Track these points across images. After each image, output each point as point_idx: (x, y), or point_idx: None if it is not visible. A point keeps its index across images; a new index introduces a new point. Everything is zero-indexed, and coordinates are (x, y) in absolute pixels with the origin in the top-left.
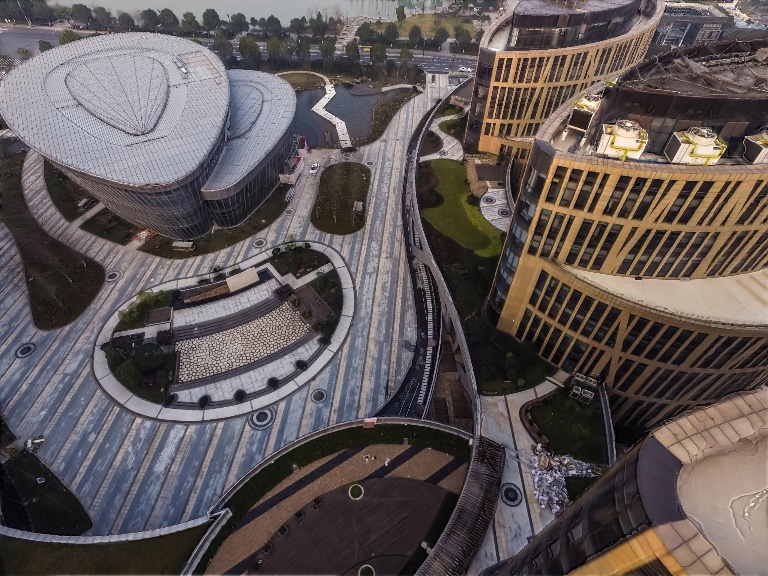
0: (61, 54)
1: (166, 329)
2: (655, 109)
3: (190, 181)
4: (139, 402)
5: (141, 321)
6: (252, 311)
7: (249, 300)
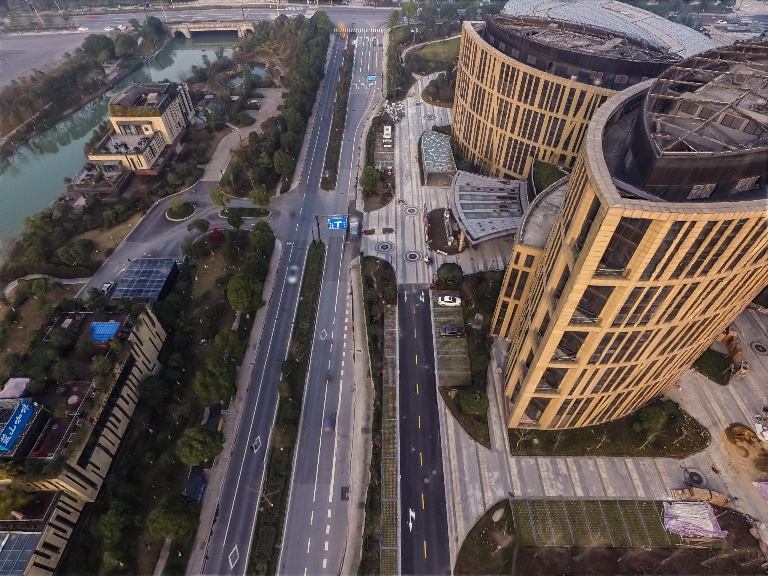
0: (521, 6)
1: None
2: None
3: None
4: None
5: None
6: None
7: None
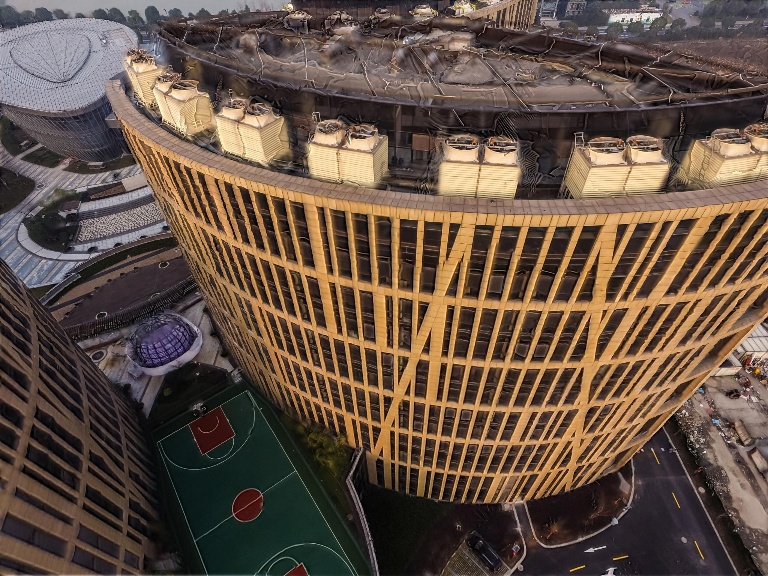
0: (10, 35)
1: (74, 213)
2: (315, 3)
3: (93, 110)
4: (46, 251)
5: (56, 209)
6: (139, 201)
7: (139, 195)
